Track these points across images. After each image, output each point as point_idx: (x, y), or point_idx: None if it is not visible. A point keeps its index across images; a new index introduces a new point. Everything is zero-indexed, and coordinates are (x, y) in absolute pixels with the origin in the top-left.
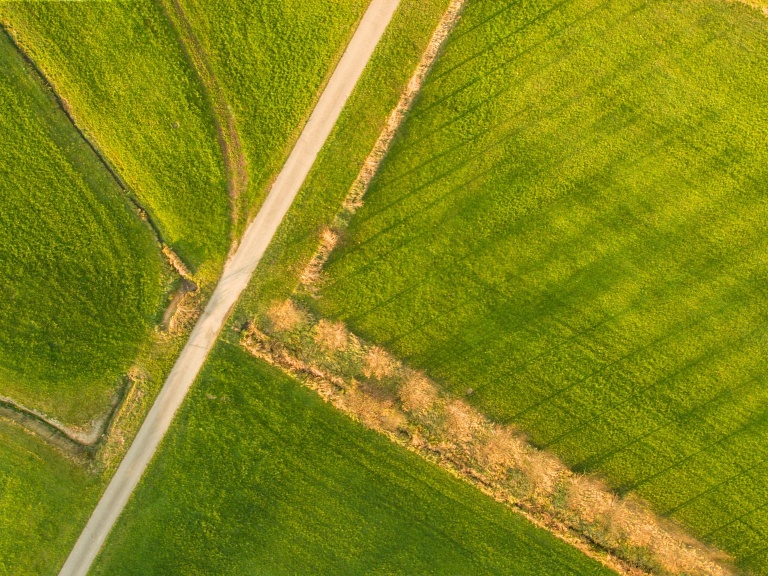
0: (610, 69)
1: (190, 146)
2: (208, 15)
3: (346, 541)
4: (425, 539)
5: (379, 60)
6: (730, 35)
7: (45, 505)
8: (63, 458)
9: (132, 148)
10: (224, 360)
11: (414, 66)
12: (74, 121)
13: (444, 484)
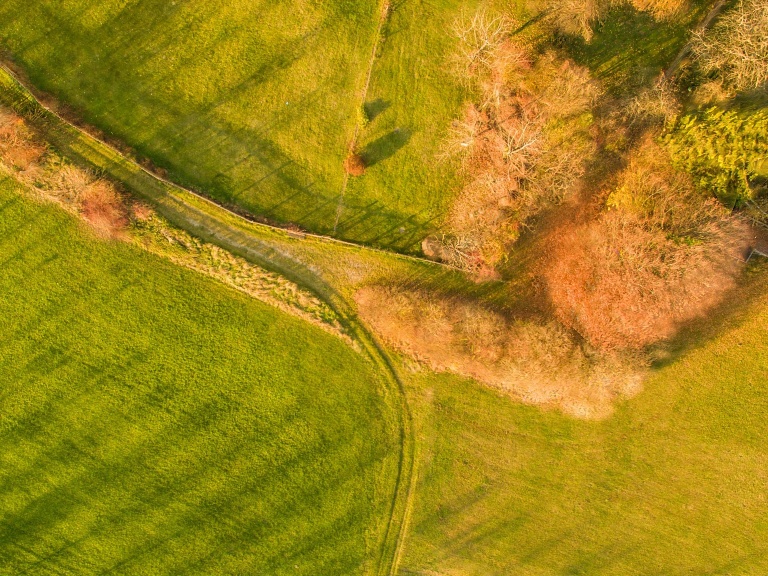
0: (34, 315)
1: None
2: None
3: None
4: None
5: None
6: (143, 281)
7: None
8: None
9: None
10: None
11: None
12: None
13: None
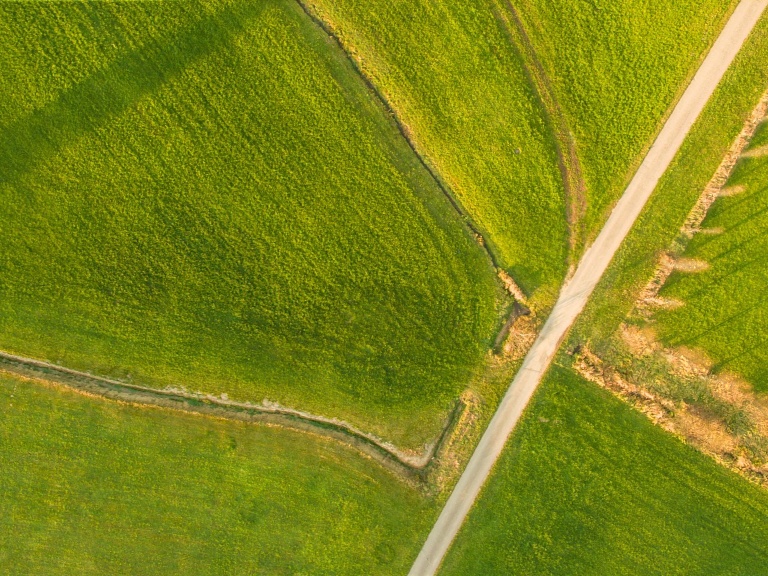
0: None
1: (531, 172)
2: (554, 42)
3: (672, 562)
4: (747, 559)
5: (726, 87)
6: None
7: (382, 528)
8: (398, 481)
9: (473, 174)
10: (557, 383)
11: (760, 93)
12: (414, 147)
13: (766, 505)
